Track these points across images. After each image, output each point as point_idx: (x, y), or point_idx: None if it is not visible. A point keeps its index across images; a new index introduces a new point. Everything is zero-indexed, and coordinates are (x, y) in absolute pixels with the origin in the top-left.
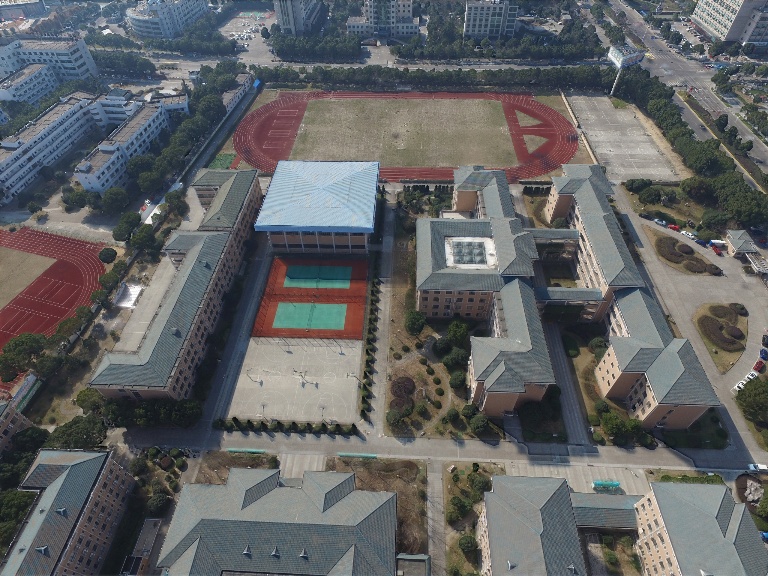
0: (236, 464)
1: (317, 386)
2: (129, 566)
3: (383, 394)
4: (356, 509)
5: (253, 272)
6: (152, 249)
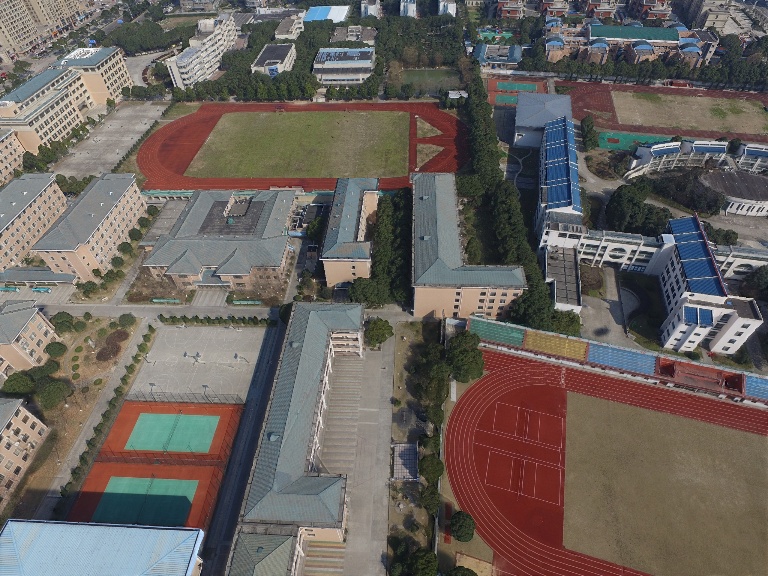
0: (257, 298)
1: (185, 354)
2: (314, 249)
3: (129, 348)
4: (169, 251)
5: (239, 512)
6: (405, 559)
